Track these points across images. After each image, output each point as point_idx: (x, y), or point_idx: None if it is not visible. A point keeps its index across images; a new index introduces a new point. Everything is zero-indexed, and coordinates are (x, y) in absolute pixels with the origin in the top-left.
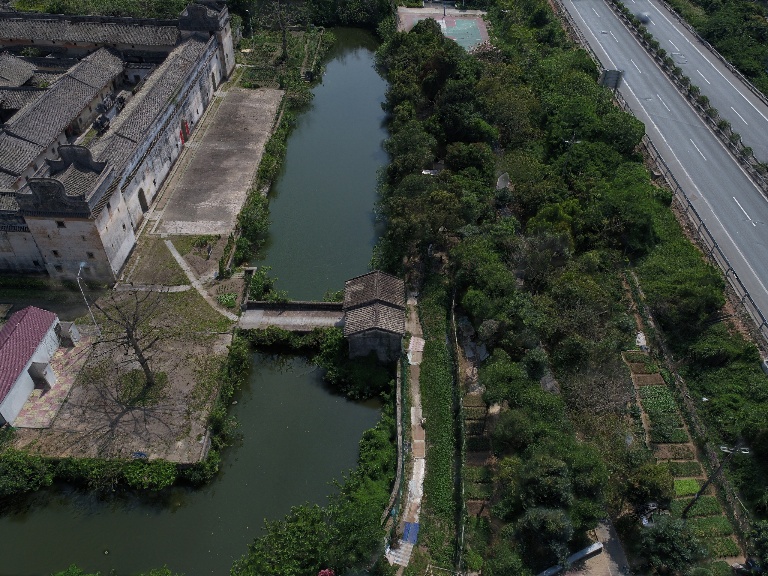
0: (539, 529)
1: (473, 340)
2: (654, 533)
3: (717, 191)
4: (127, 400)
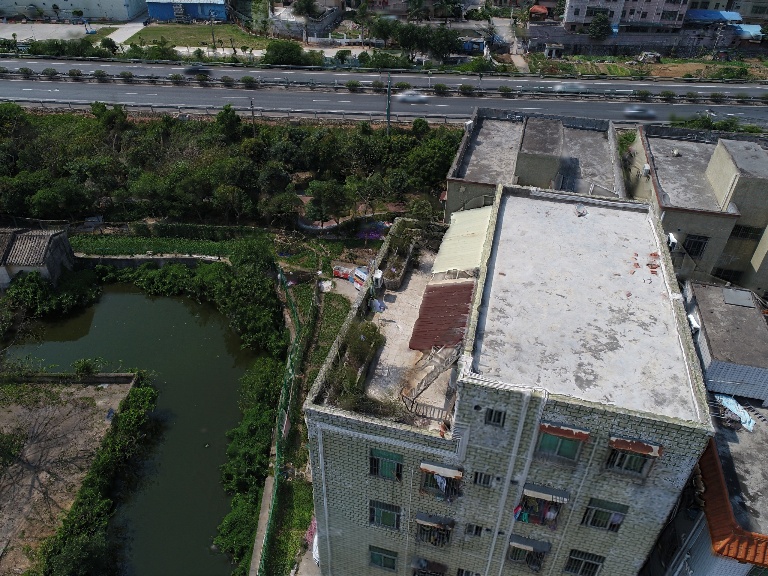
0: (275, 172)
1: (76, 225)
2: (281, 152)
3: (6, 92)
4: (2, 466)
